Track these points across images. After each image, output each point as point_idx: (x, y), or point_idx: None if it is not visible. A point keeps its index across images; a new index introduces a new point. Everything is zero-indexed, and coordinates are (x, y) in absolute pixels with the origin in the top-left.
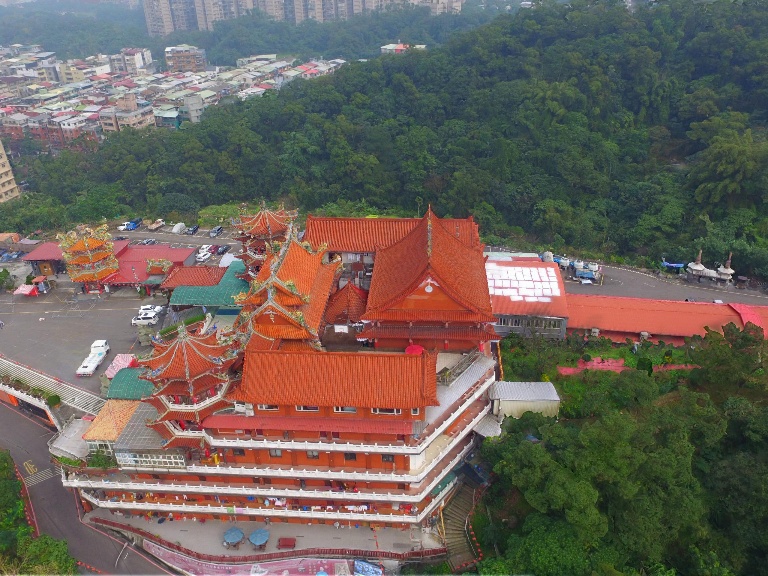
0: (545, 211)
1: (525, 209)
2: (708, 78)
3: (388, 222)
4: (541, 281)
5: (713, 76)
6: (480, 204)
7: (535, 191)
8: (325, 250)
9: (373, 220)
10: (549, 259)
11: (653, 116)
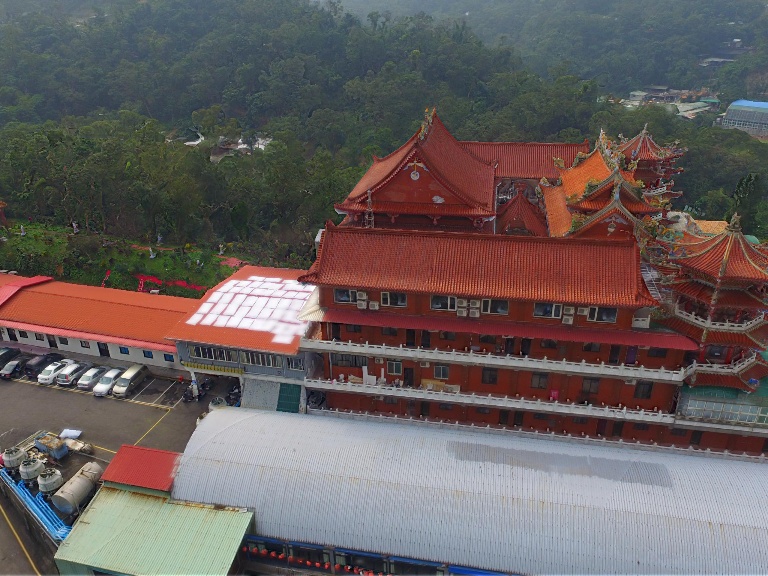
0: None
1: None
2: None
3: (477, 238)
4: (238, 293)
5: None
6: None
7: None
8: (569, 204)
9: (506, 238)
10: (93, 463)
11: None
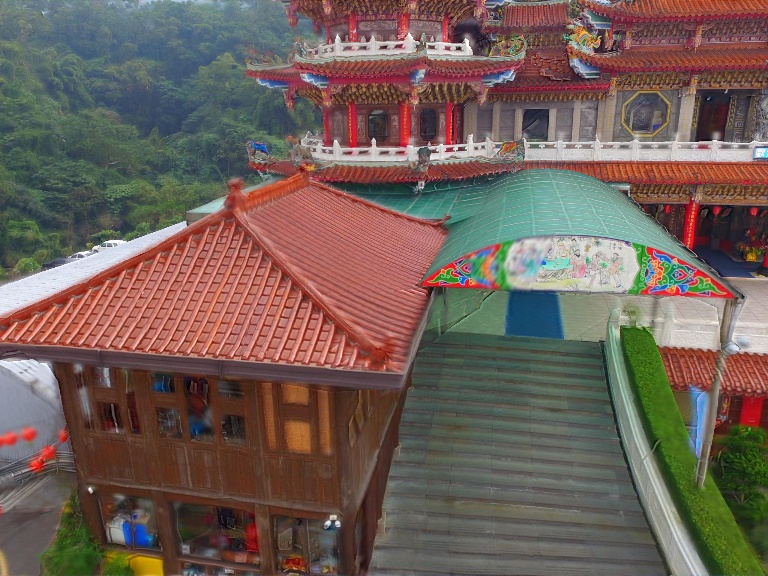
0: (132, 197)
1: (87, 212)
2: (98, 59)
3: None
4: None
5: (101, 58)
6: (8, 226)
7: (89, 178)
8: None
9: None
10: None
11: (75, 103)
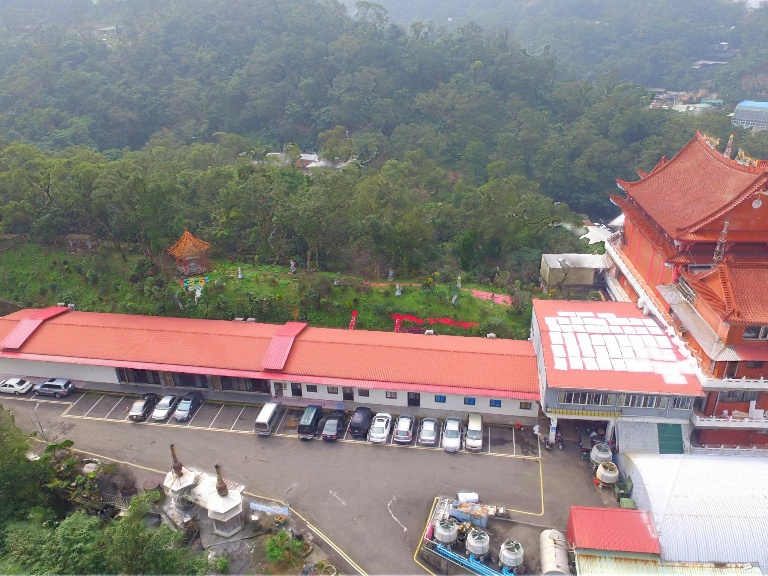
0: None
1: None
2: None
3: None
4: (577, 332)
5: None
6: None
7: None
8: None
9: None
10: (556, 531)
11: None
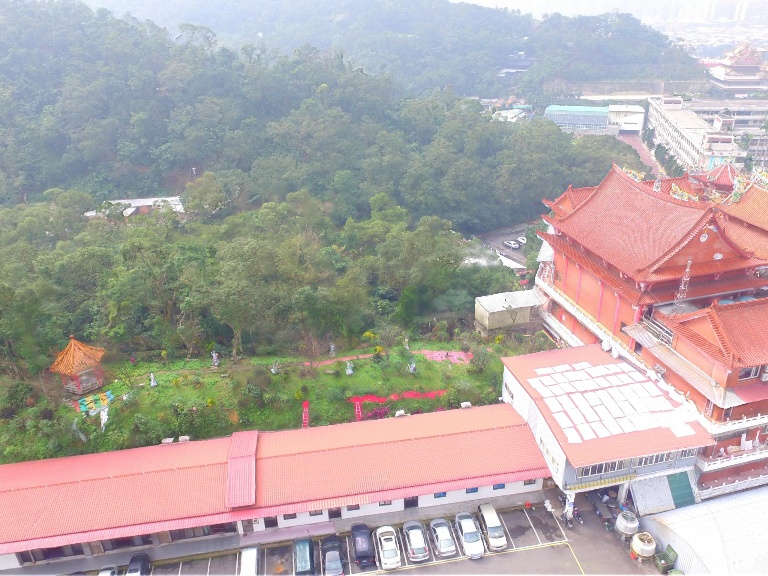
0: None
1: None
2: None
3: None
4: (569, 393)
5: None
6: None
7: None
8: None
9: None
10: None
11: None
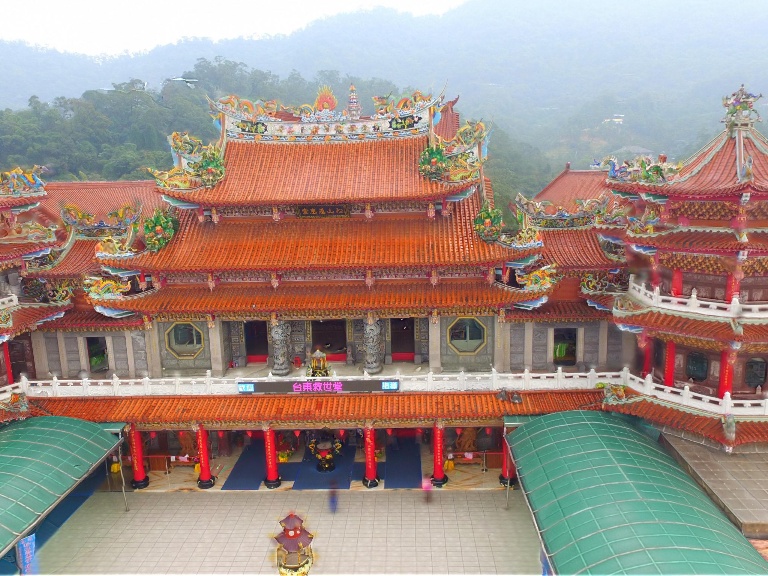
0: None
1: None
2: None
3: (124, 188)
4: None
5: None
6: None
7: None
8: None
9: (106, 185)
10: None
11: None
